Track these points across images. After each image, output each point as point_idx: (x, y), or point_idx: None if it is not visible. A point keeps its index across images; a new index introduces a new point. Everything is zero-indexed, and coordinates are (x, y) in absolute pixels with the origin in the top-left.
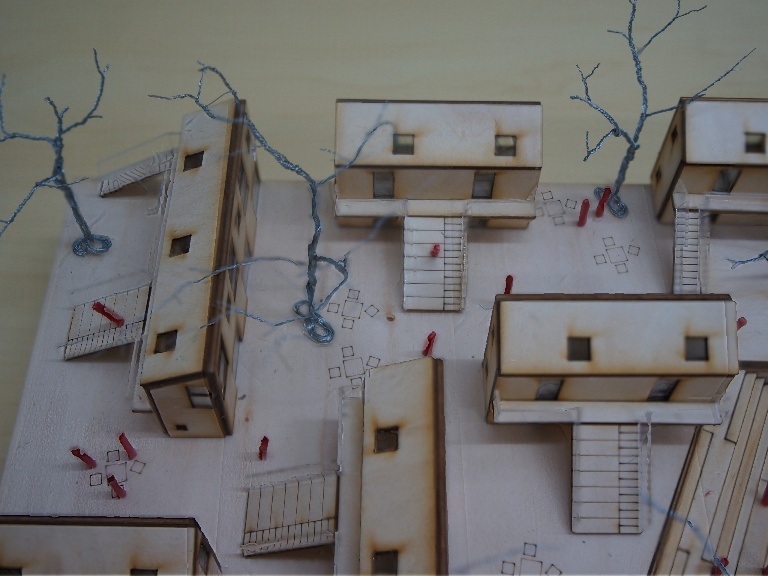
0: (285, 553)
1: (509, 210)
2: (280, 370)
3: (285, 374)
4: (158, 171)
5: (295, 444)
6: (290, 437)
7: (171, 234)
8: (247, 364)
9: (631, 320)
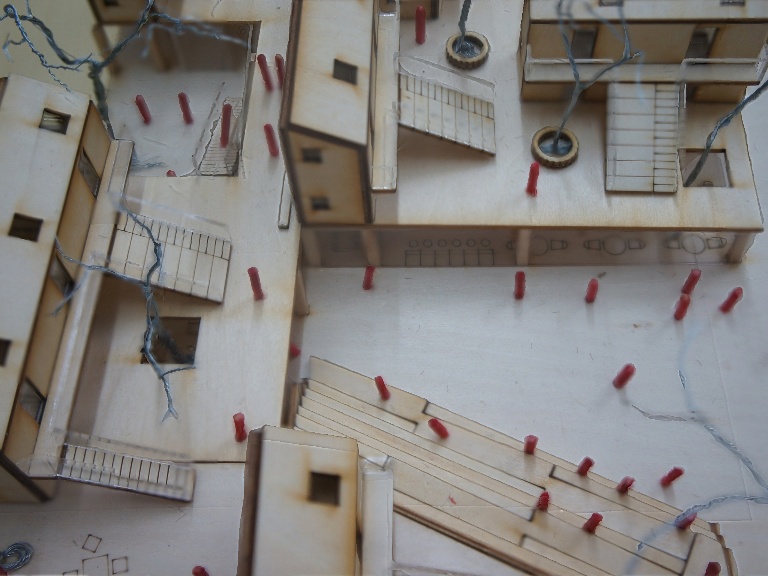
0: None
1: None
2: None
3: None
4: None
5: None
6: None
7: None
8: None
9: (281, 575)
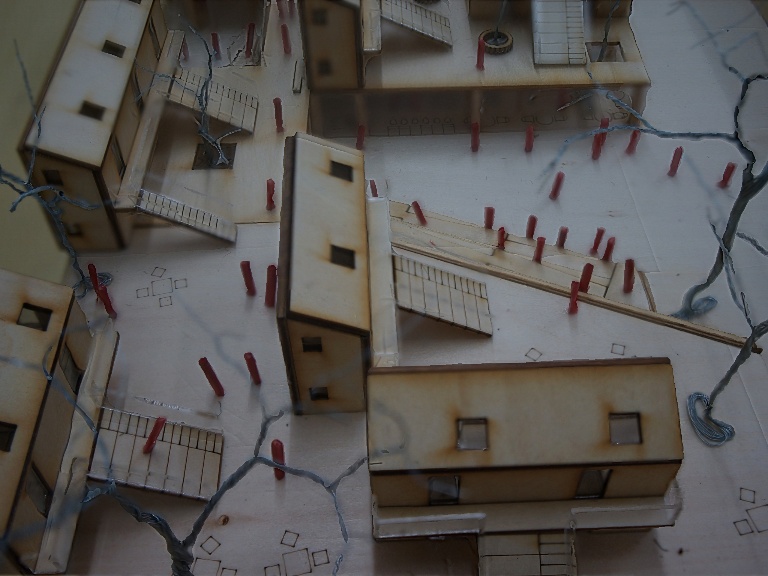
0: None
1: (104, 355)
2: None
3: None
4: None
5: None
6: None
7: None
8: None
9: (314, 208)
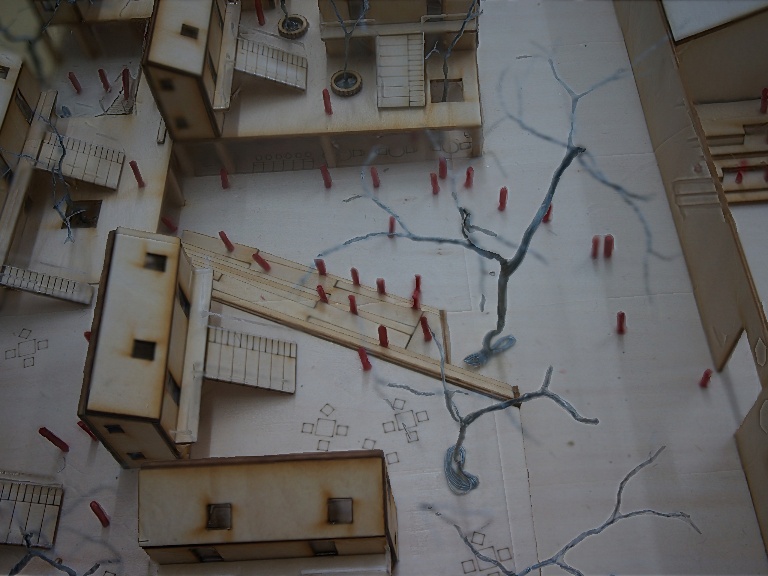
0: None
1: None
2: None
3: None
4: None
5: None
6: None
7: None
8: None
9: (123, 305)
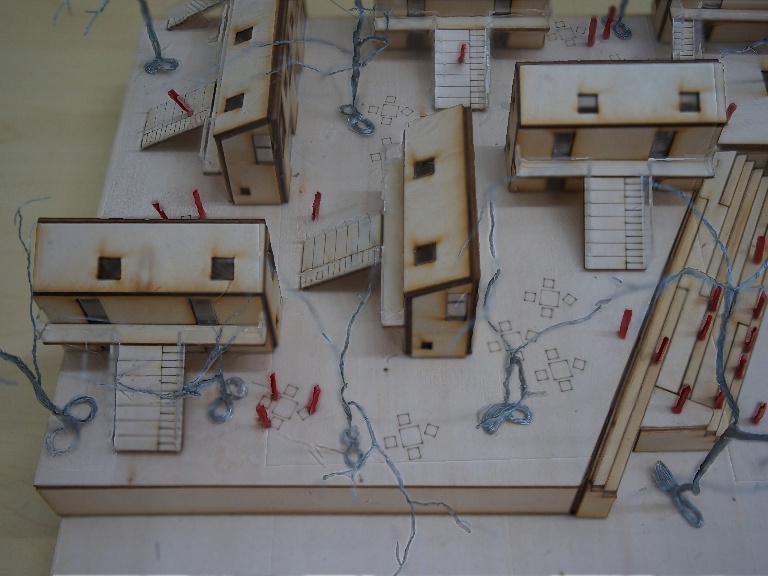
0: (337, 281)
1: (526, 23)
2: (328, 155)
3: (333, 158)
4: (219, 1)
5: (343, 209)
6: (338, 204)
7: (235, 29)
8: (299, 151)
9: (633, 79)
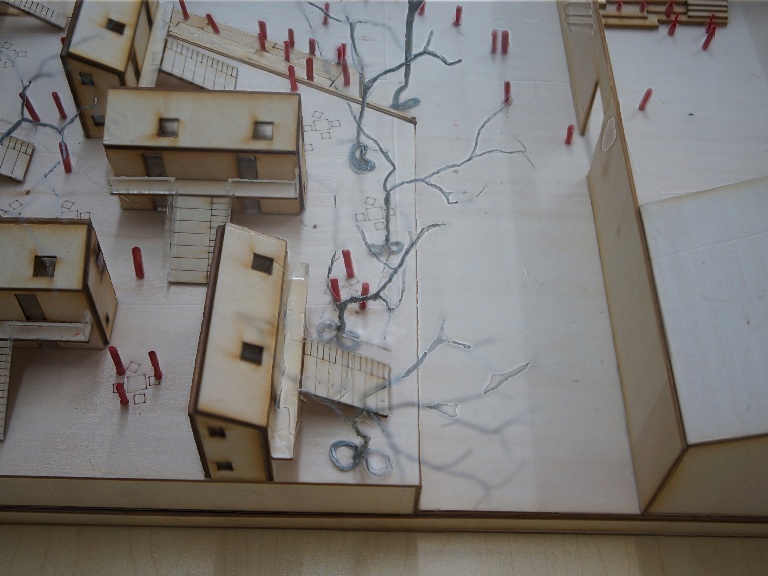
0: None
1: None
2: None
3: None
4: None
5: None
6: (126, 258)
7: None
8: None
9: None
